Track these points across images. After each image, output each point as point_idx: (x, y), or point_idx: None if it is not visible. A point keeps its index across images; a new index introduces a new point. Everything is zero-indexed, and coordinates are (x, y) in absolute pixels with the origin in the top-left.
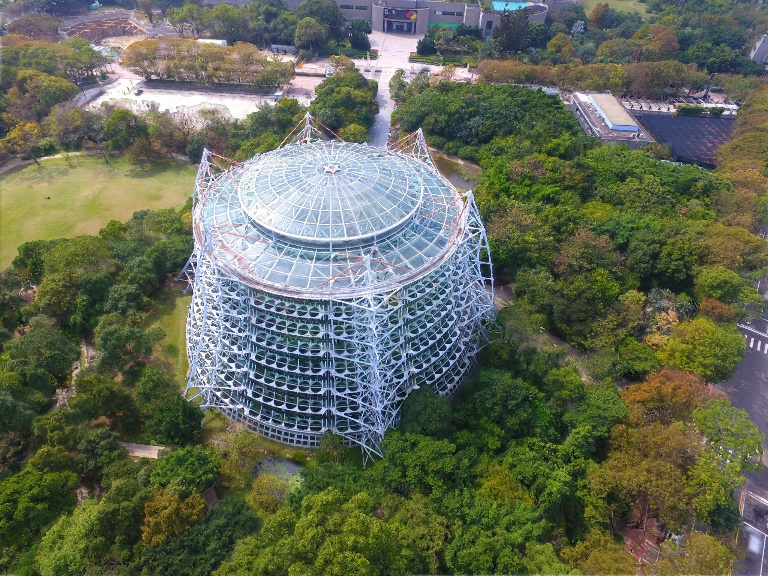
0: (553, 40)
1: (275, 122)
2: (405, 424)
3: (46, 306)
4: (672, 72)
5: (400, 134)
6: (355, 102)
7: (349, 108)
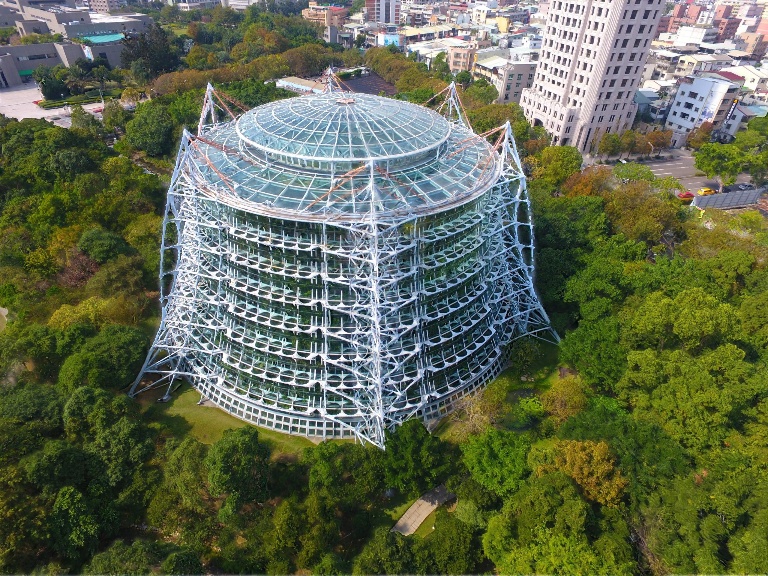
0: (191, 54)
1: (4, 187)
2: (544, 287)
3: (1, 566)
4: (315, 52)
5: (151, 161)
6: (82, 139)
7: (80, 147)
